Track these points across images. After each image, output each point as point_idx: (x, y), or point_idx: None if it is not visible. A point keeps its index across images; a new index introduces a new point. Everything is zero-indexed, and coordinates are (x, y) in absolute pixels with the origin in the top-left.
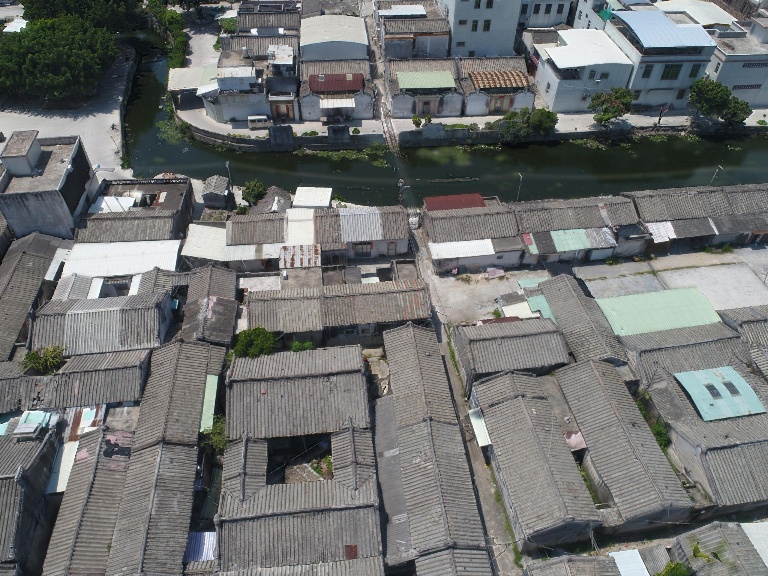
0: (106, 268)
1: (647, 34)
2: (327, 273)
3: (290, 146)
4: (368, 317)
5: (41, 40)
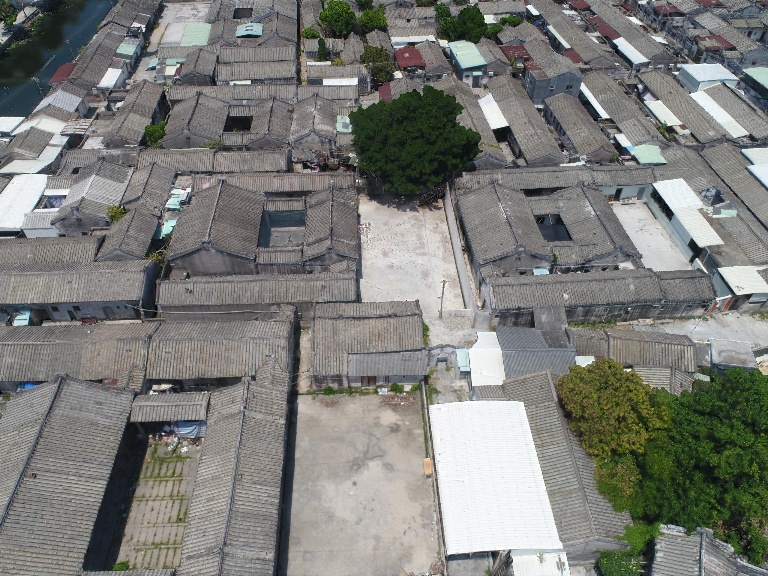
0: (25, 206)
1: None
2: None
3: None
4: (152, 104)
5: None
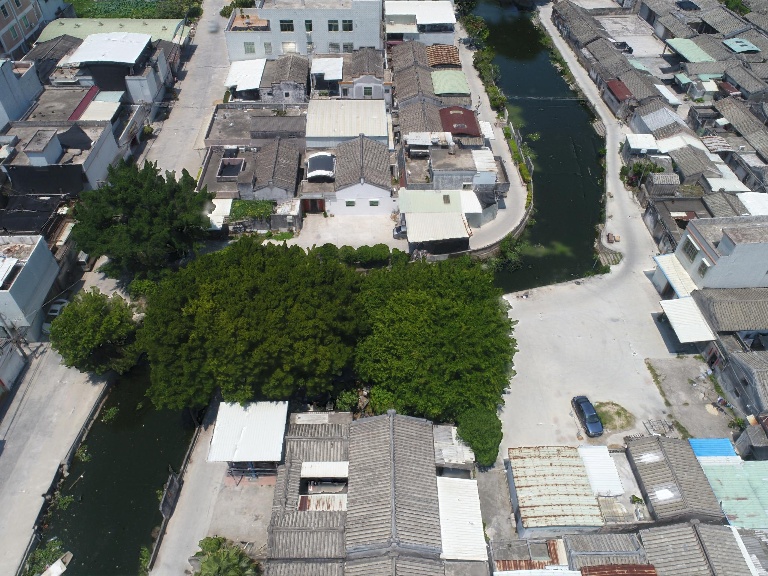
0: None
1: None
2: None
3: None
4: None
5: None
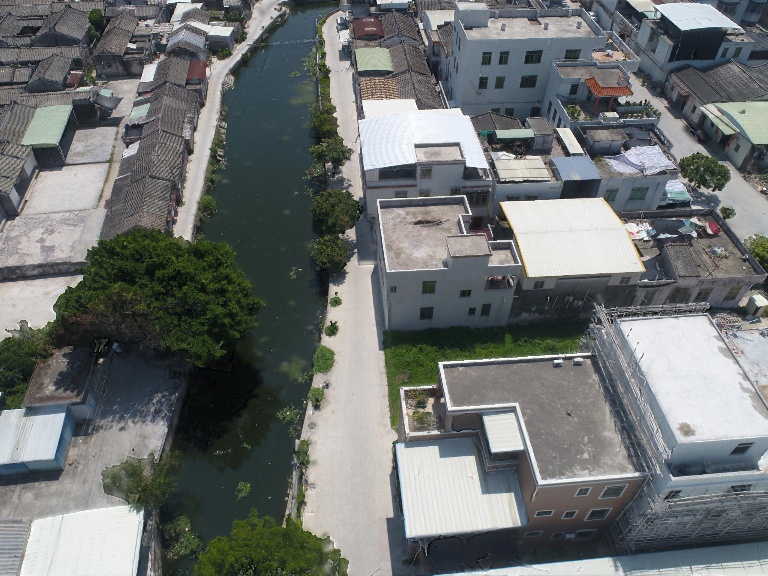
0: None
1: (387, 122)
2: None
3: None
4: None
5: None
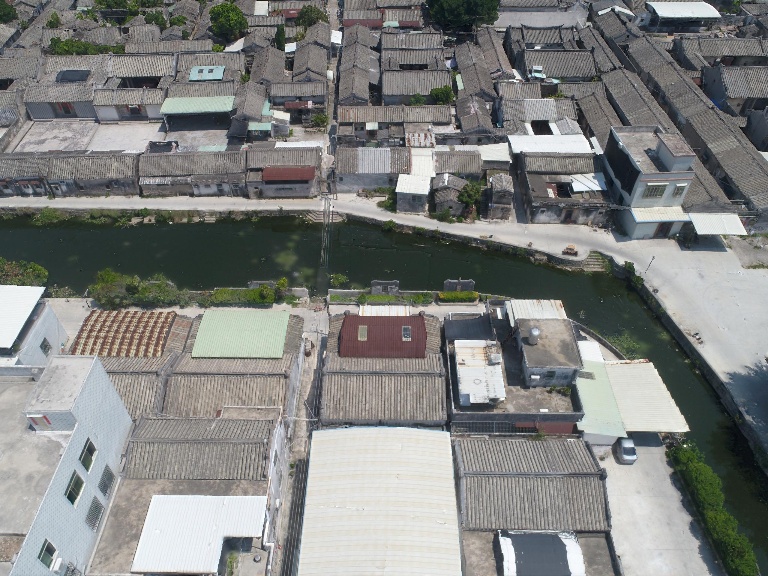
0: None
1: None
2: None
3: None
4: None
5: None
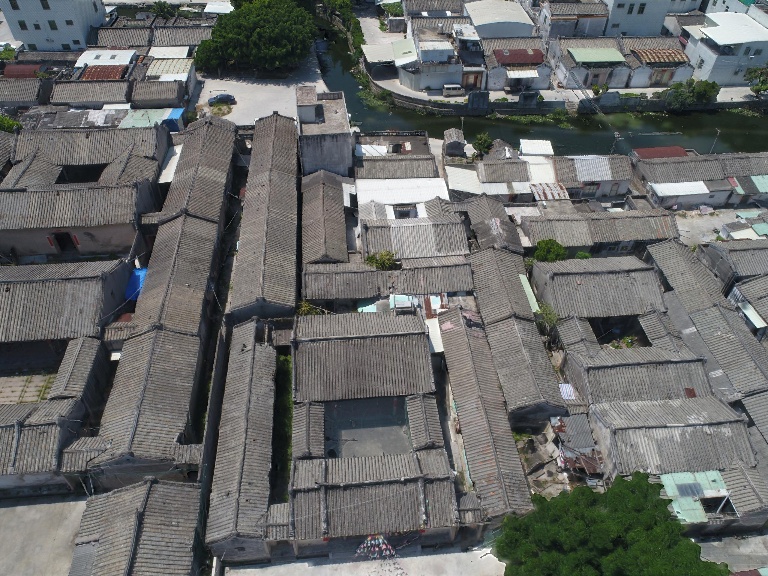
0: (392, 198)
1: None
2: (574, 205)
3: (484, 111)
4: (628, 236)
5: (263, 17)
